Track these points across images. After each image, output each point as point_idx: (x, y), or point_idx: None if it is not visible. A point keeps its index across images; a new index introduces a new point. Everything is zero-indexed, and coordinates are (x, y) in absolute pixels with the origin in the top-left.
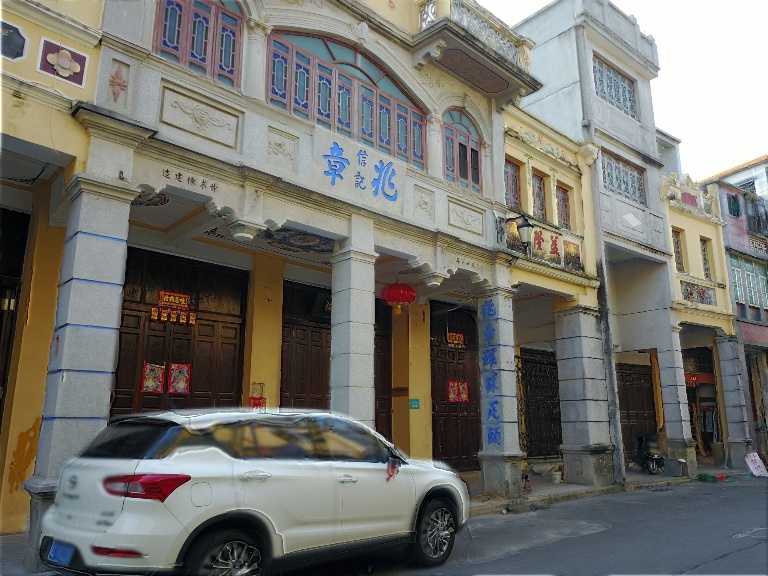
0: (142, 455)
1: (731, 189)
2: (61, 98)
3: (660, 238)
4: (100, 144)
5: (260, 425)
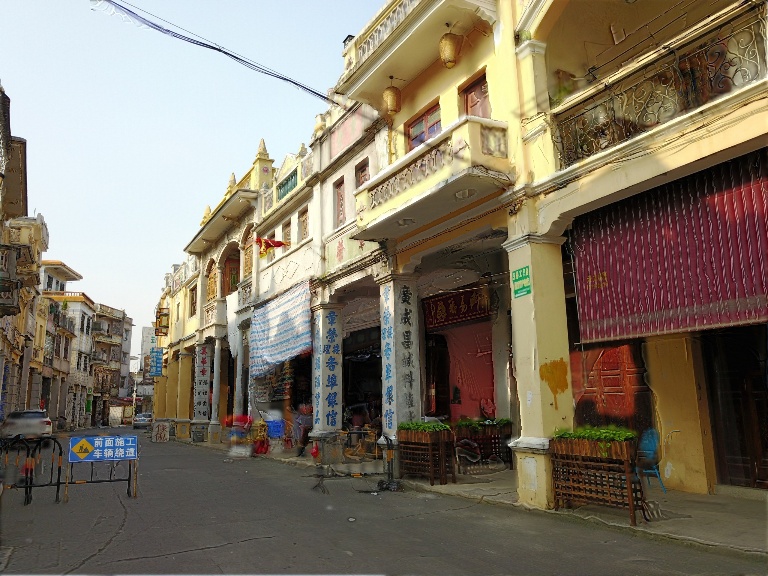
0: None
1: (52, 301)
2: None
3: (33, 329)
4: None
5: None
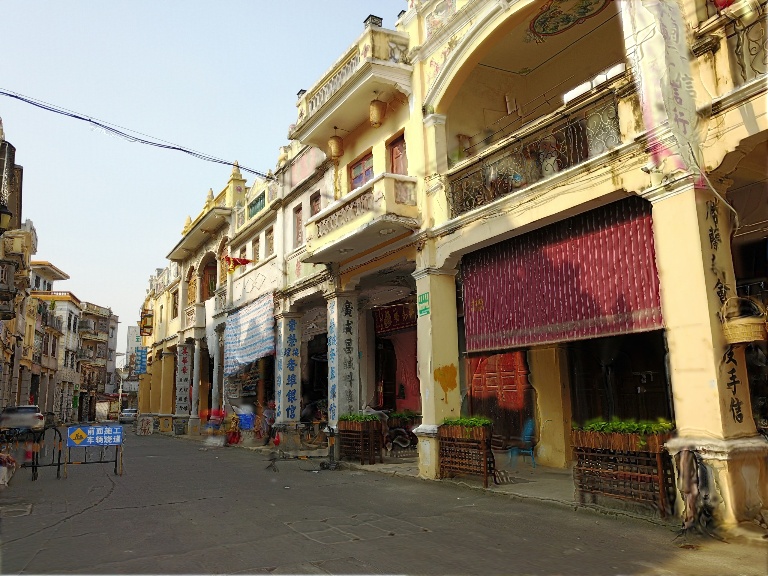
0: None
1: None
2: None
3: (23, 329)
4: None
5: None
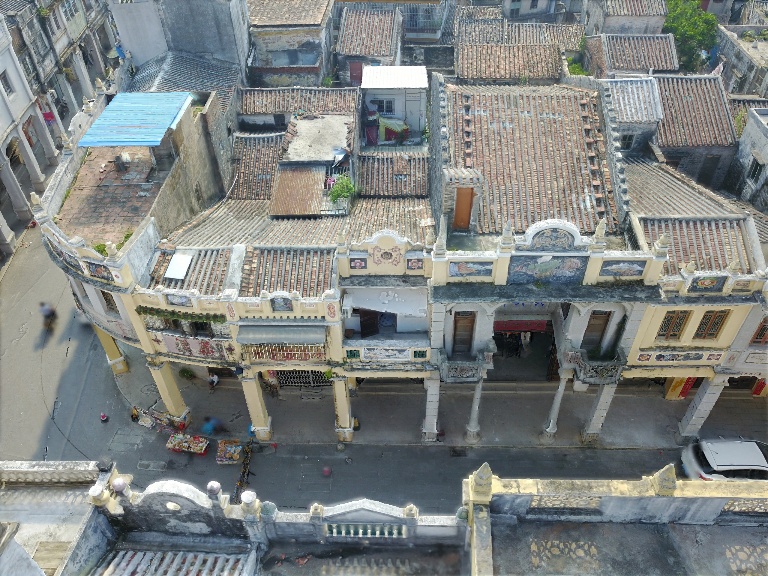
0: (705, 472)
1: None
2: (711, 366)
3: None
4: (719, 375)
5: (736, 470)
